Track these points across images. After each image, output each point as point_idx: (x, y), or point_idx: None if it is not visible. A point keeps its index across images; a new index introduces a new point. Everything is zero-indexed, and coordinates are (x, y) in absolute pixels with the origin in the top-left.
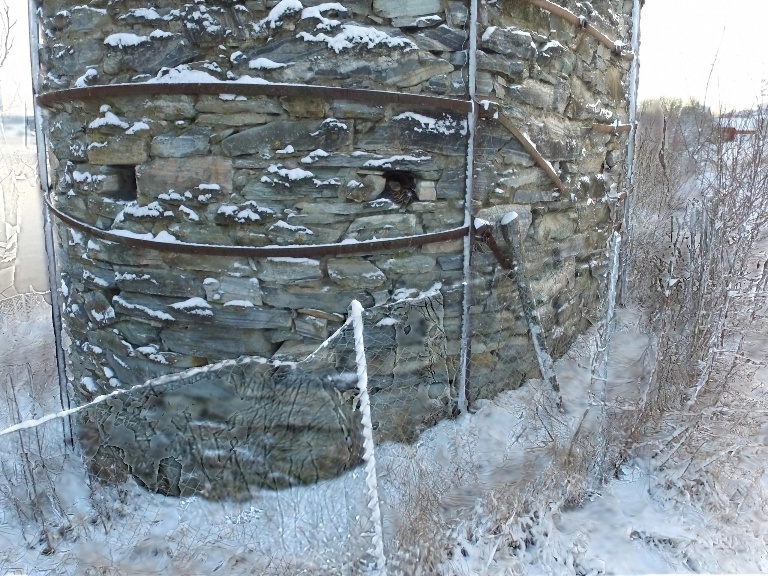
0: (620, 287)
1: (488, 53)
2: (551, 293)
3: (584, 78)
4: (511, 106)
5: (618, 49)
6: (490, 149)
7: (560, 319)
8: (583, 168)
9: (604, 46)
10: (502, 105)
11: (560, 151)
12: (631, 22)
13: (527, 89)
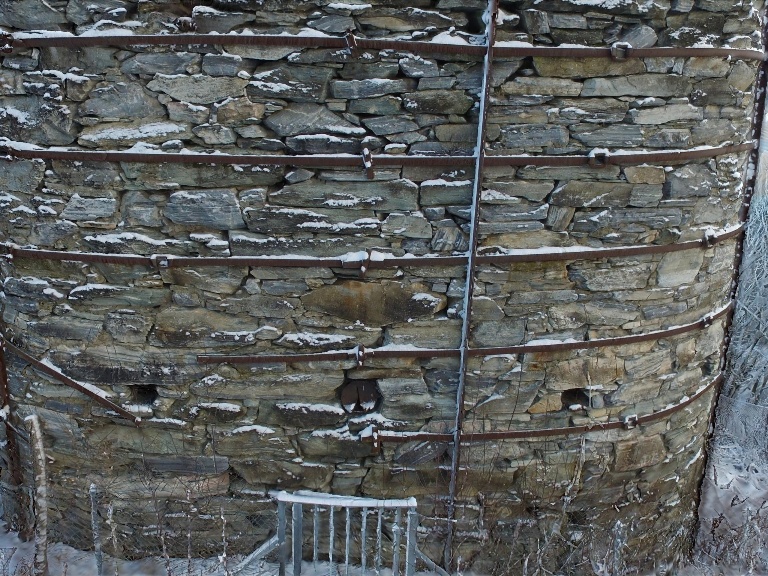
0: (443, 548)
1: (9, 296)
2: (137, 494)
3: (208, 306)
4: (30, 336)
5: (344, 265)
6: (19, 363)
7: (173, 523)
8: (222, 394)
9: (285, 267)
10: (24, 334)
11: (123, 376)
12: (465, 213)
13: (47, 325)
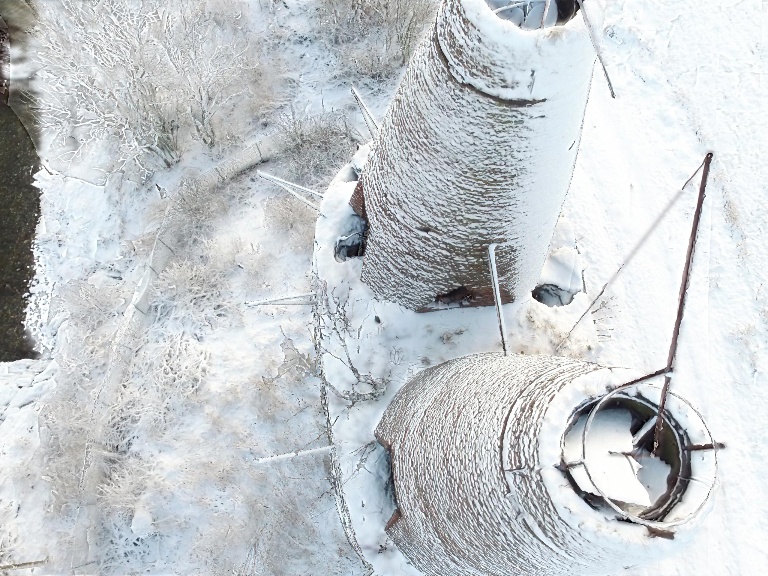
0: None
1: None
2: None
3: None
4: None
5: None
6: None
7: None
8: None
9: None
10: None
11: None
12: None
13: None
